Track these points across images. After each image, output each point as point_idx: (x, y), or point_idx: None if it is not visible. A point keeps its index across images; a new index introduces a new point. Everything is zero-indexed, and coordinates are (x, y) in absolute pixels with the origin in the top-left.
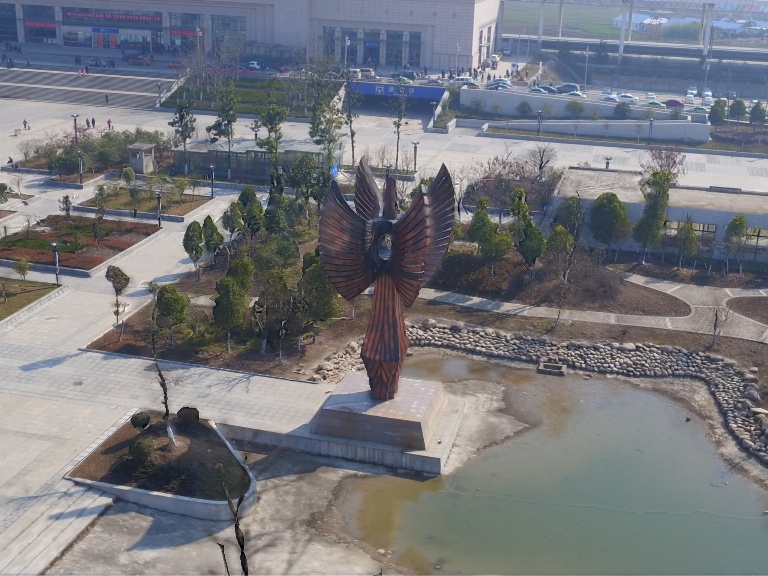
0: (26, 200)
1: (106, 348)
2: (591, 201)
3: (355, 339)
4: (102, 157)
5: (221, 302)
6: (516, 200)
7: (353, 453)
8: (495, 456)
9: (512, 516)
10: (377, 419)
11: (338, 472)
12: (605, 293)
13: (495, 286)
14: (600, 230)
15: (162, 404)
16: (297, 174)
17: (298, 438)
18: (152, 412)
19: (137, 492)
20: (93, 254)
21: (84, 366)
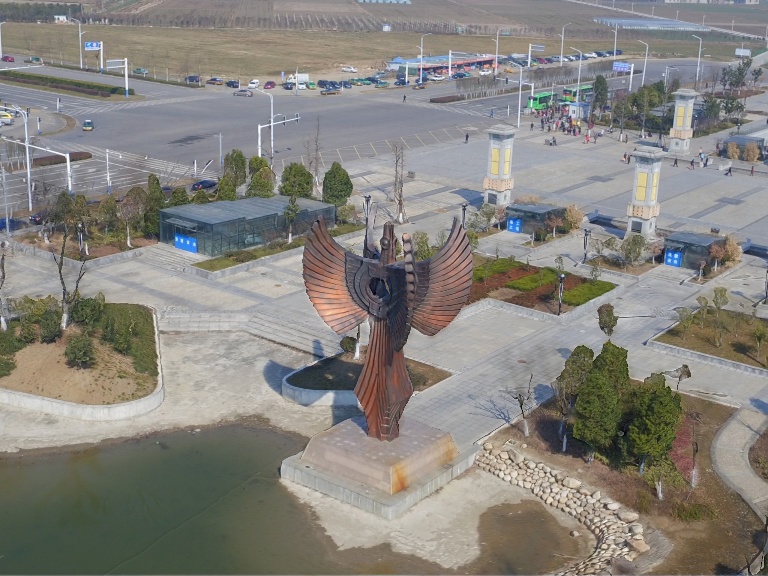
0: None
1: None
2: None
3: (600, 491)
4: None
5: None
6: None
7: None
8: (292, 511)
9: (192, 491)
10: None
11: None
12: None
13: None
14: None
15: None
16: None
17: None
18: None
19: None
20: None
21: (559, 366)
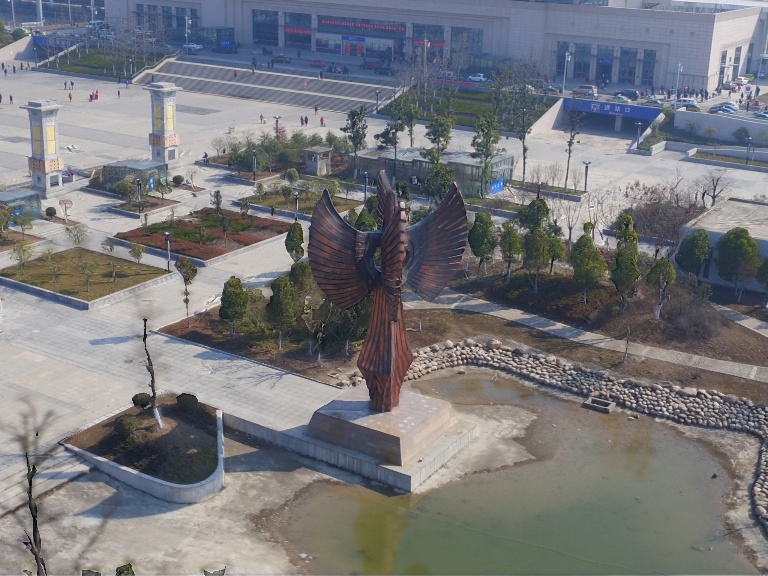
0: (196, 192)
1: (174, 332)
2: (722, 235)
3: None
4: (282, 157)
5: (273, 300)
6: (623, 227)
7: (335, 459)
8: (479, 483)
9: (456, 544)
10: (362, 429)
11: (314, 475)
12: (696, 333)
13: (583, 314)
14: (724, 267)
15: (149, 387)
16: (431, 185)
17: (290, 437)
18: (174, 395)
19: (110, 464)
20: (219, 246)
21: None
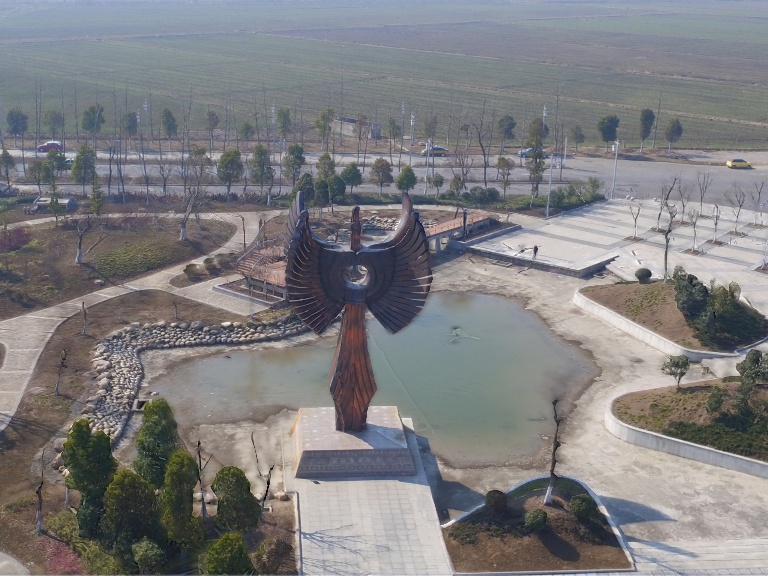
0: None
1: None
2: None
3: None
4: None
5: None
6: None
7: None
8: None
9: (446, 406)
10: None
11: (448, 471)
12: None
13: None
14: None
15: None
16: None
17: None
18: (454, 567)
19: None
20: None
21: None
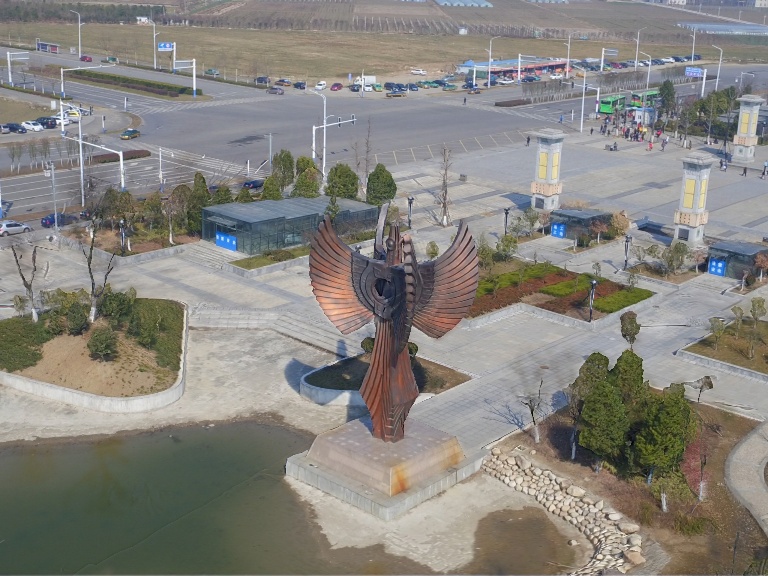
0: None
1: None
2: None
3: (604, 501)
4: None
5: None
6: None
7: None
8: (292, 508)
9: (197, 484)
10: None
11: None
12: None
13: None
14: None
15: None
16: None
17: None
18: None
19: None
20: None
21: None
